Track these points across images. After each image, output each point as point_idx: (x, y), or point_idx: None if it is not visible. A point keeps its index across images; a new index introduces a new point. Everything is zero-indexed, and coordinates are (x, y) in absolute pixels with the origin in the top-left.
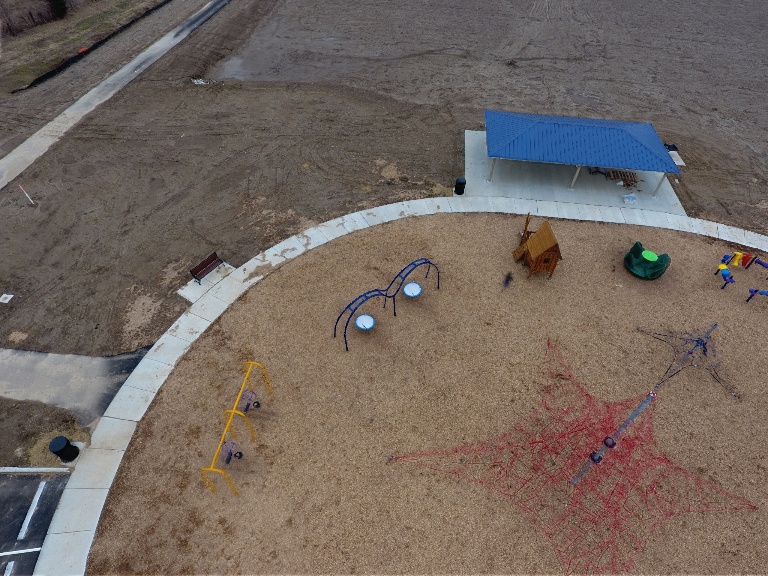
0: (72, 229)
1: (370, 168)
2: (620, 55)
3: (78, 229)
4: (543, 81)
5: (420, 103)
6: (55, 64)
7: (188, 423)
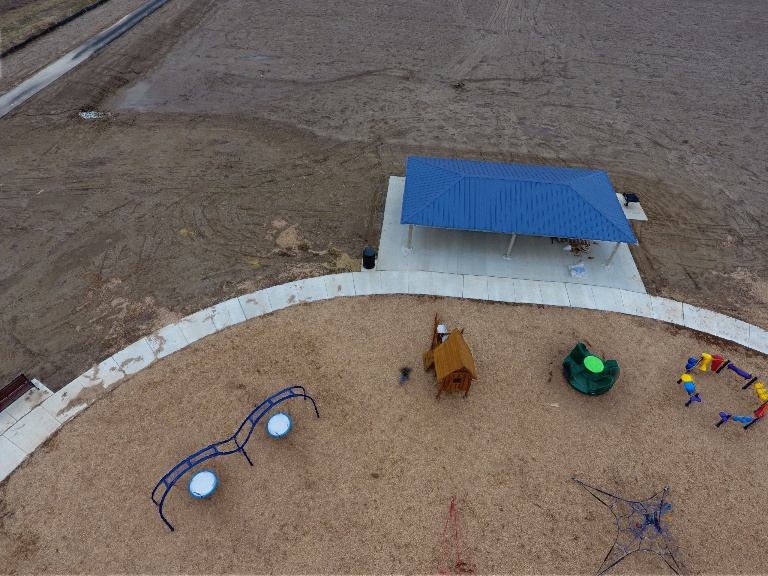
0: None
1: (264, 233)
2: (582, 74)
3: None
4: (492, 108)
5: (345, 139)
6: None
7: None
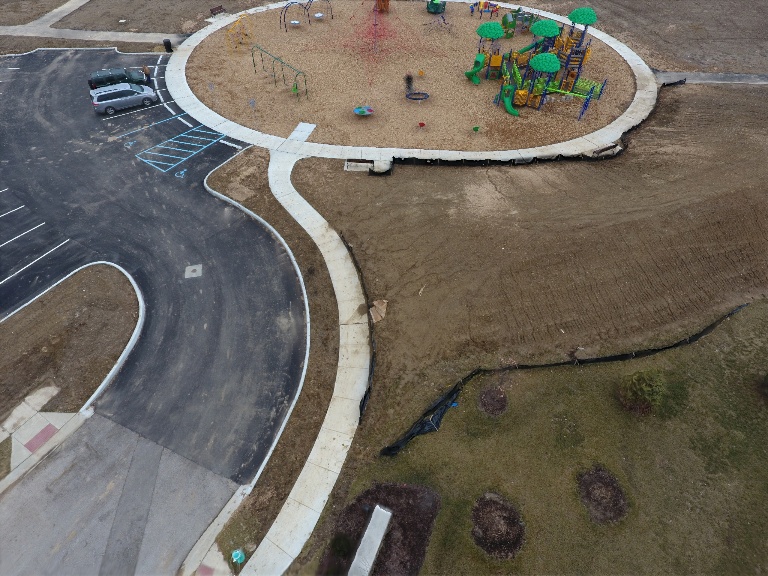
0: (145, 4)
1: None
2: None
3: (148, 4)
4: None
5: None
6: None
7: (217, 45)
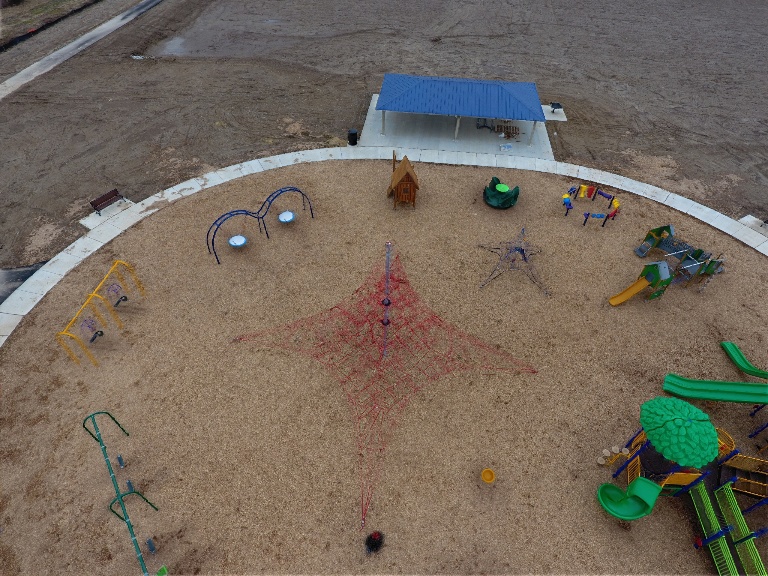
0: None
1: (277, 125)
2: (540, 32)
3: None
4: (461, 55)
5: (340, 73)
6: (4, 42)
7: (67, 316)
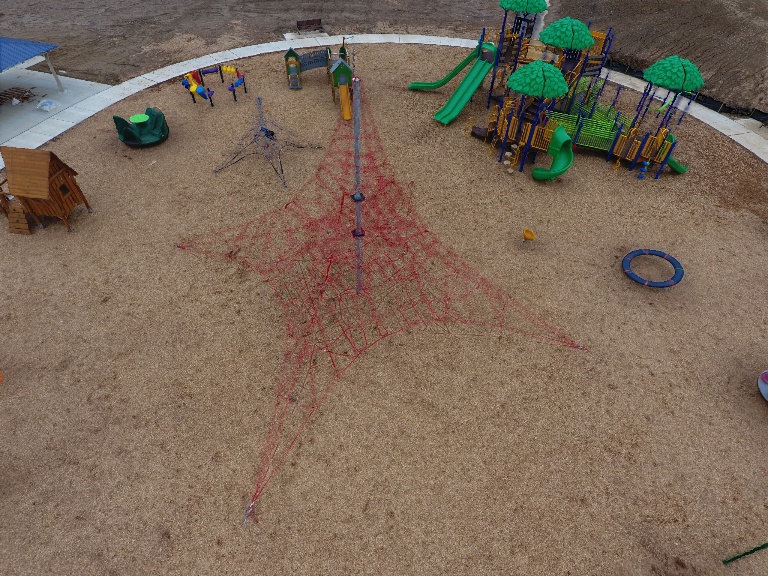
0: None
1: None
2: None
3: None
4: None
5: None
6: None
7: None
